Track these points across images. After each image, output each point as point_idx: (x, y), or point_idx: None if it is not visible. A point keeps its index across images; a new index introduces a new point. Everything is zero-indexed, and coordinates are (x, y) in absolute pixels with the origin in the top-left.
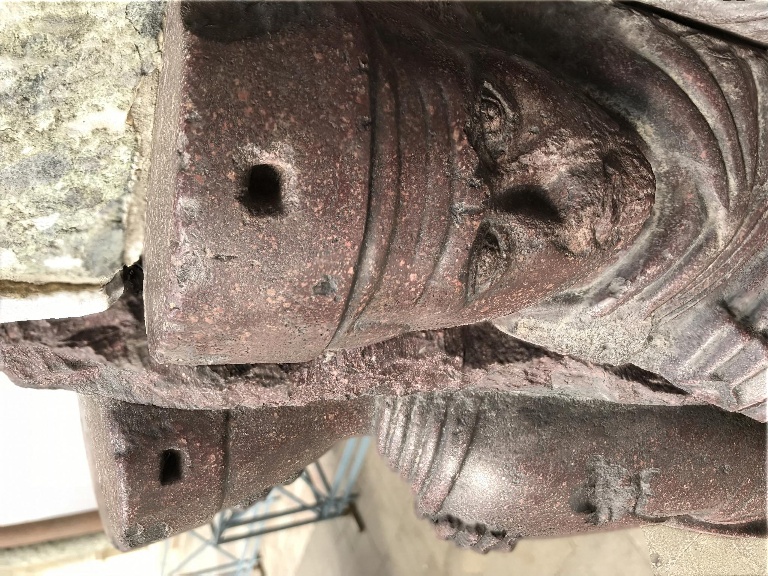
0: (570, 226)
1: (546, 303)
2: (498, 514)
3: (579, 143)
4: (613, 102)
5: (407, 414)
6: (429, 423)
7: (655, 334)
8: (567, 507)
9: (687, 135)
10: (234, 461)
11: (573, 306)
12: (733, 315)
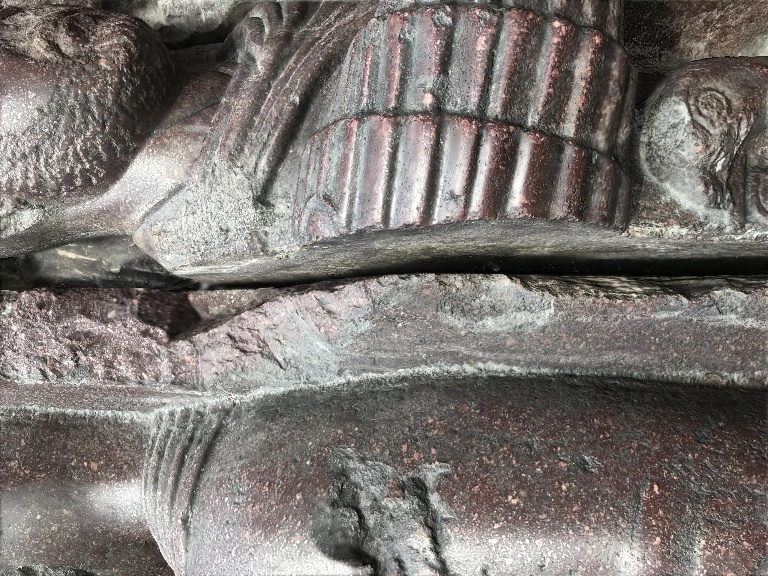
0: (25, 39)
1: (163, 201)
2: (230, 572)
3: (55, 9)
4: None
5: (160, 451)
6: (176, 454)
7: (276, 201)
8: (314, 545)
9: None
10: None
11: (181, 193)
12: (316, 132)
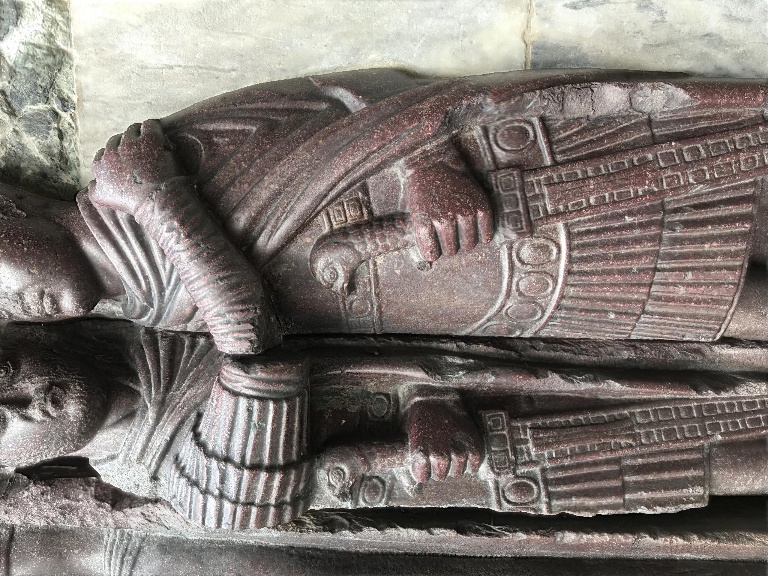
0: (31, 409)
1: (105, 460)
2: None
3: (41, 378)
4: (134, 365)
5: (111, 550)
6: None
7: (161, 477)
8: None
9: None
10: (12, 567)
11: (114, 461)
12: (177, 460)
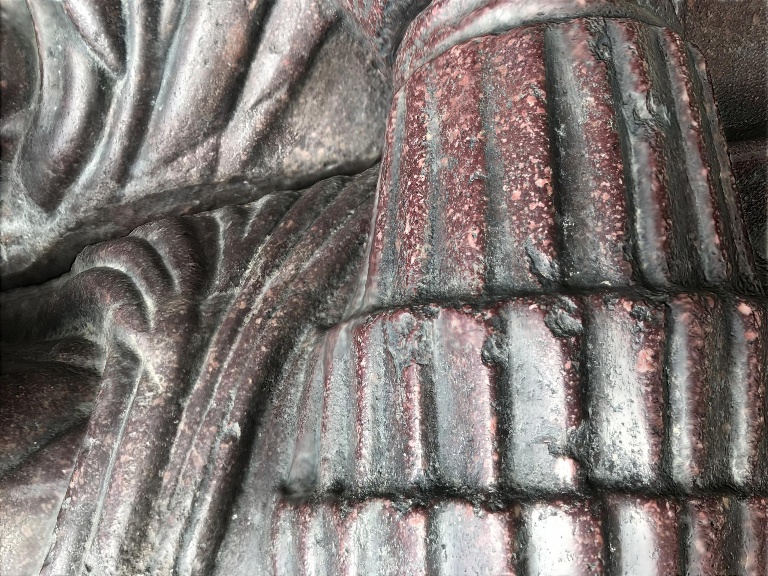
0: None
1: None
2: None
3: None
4: (65, 331)
5: None
6: None
7: None
8: None
9: (96, 295)
10: None
11: None
12: (290, 492)
